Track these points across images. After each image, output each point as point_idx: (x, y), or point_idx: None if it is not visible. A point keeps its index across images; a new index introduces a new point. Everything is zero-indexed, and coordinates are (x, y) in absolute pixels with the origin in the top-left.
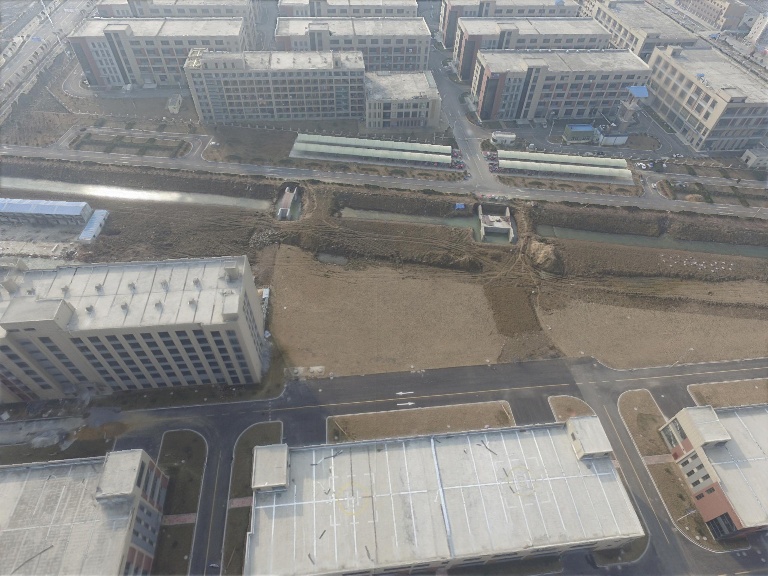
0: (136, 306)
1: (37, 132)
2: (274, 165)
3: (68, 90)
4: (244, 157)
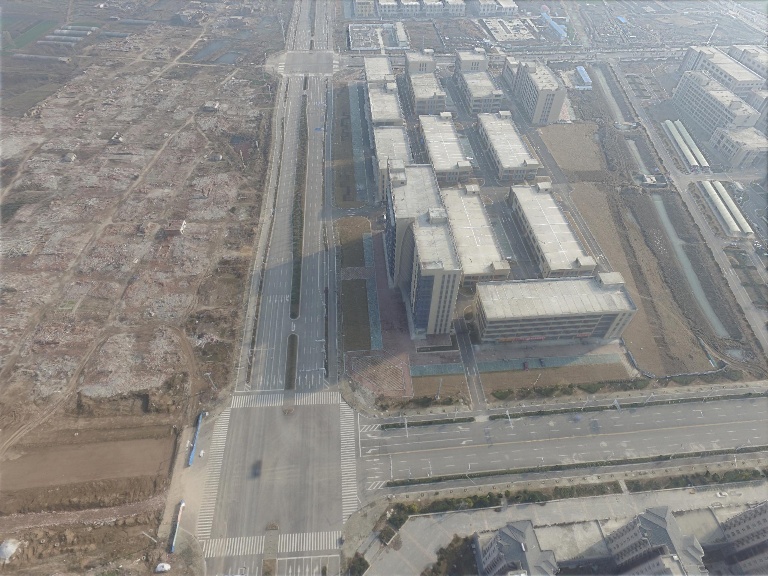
0: (541, 79)
1: (628, 66)
2: (650, 119)
3: (669, 67)
4: (650, 111)
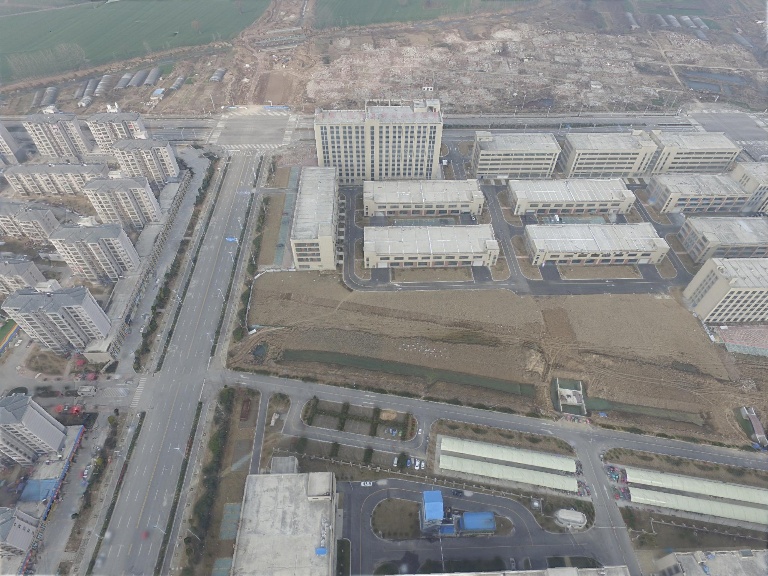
0: (761, 270)
1: None
2: None
3: None
4: None
